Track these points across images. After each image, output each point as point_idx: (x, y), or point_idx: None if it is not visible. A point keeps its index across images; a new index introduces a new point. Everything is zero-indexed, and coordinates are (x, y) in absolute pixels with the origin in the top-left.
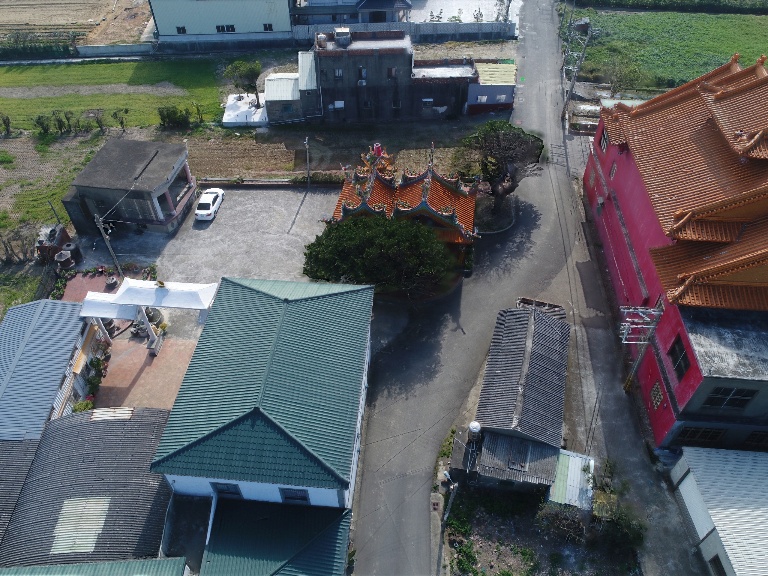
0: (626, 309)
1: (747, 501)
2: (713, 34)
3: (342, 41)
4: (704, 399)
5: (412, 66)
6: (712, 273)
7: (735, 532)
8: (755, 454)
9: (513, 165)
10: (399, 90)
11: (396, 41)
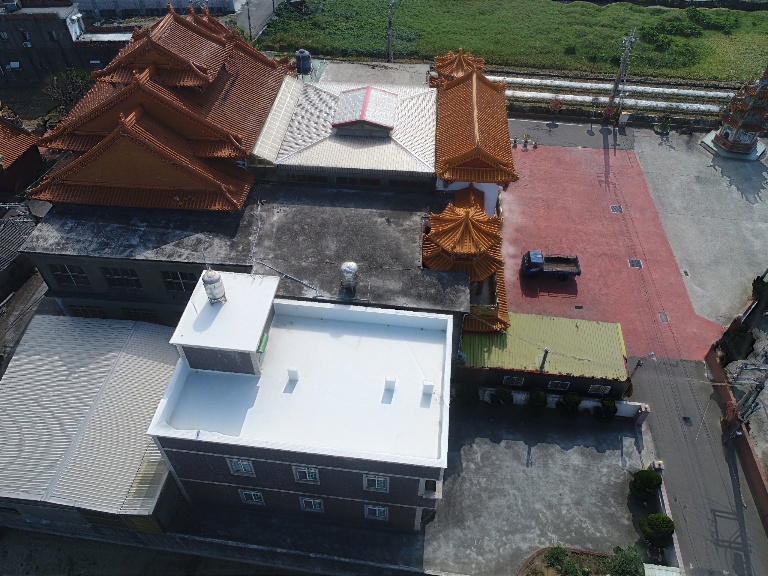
0: (1, 205)
1: (46, 350)
2: (416, 12)
3: (9, 7)
4: (52, 276)
5: (70, 30)
6: (62, 174)
7: (17, 371)
8: (84, 319)
9: (71, 108)
10: (66, 52)
11: (61, 8)
